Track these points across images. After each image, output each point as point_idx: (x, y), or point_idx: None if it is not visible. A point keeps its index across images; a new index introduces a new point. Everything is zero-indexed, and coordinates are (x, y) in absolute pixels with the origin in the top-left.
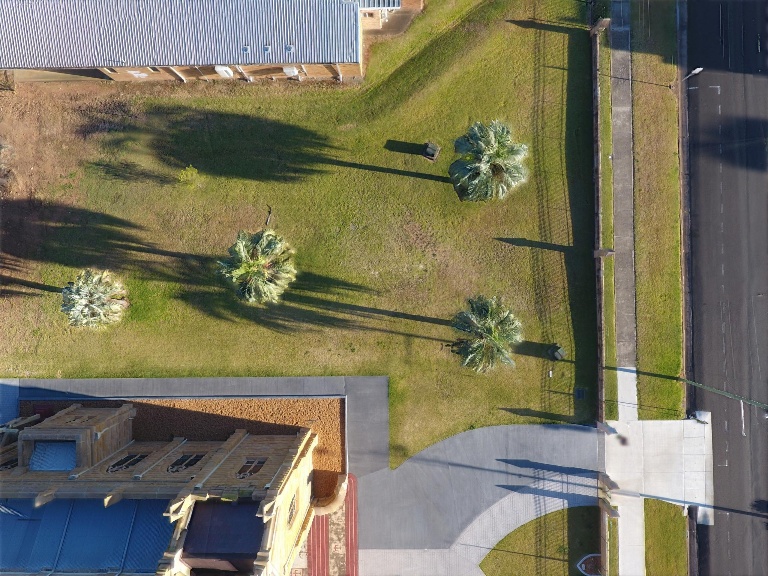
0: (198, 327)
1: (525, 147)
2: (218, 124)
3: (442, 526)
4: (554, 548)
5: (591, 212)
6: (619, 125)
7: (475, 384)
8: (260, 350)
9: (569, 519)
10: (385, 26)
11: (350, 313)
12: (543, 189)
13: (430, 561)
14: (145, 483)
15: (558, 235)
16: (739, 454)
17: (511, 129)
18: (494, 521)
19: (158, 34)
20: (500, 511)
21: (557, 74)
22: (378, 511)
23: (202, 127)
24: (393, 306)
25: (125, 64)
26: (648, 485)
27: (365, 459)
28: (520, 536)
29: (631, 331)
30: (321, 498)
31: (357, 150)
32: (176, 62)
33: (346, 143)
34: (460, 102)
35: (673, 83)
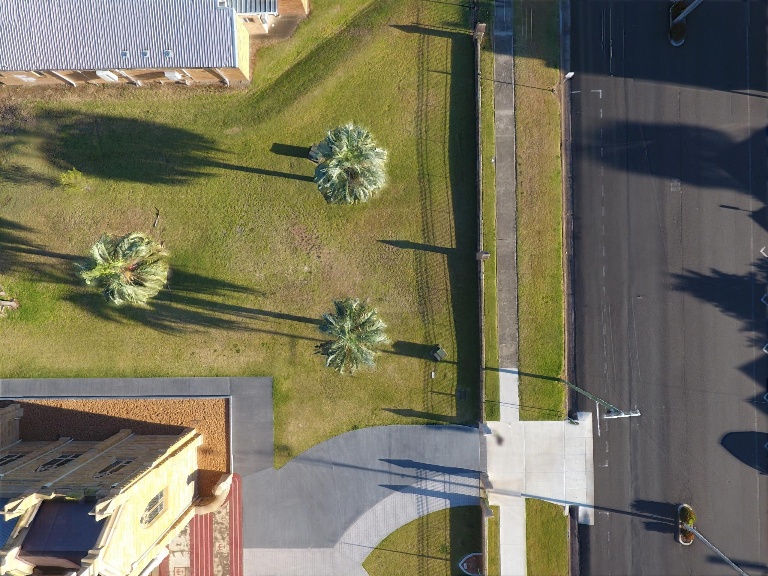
0: (86, 328)
1: (380, 151)
2: (107, 127)
3: (326, 525)
4: (436, 547)
5: (474, 215)
6: (502, 129)
7: (358, 385)
8: (147, 351)
9: (451, 519)
10: (271, 31)
11: (235, 314)
12: (426, 192)
13: (314, 560)
14: (3, 482)
15: (441, 237)
16: (619, 454)
17: (395, 132)
18: (377, 520)
19: (38, 39)
20: (383, 511)
21: (440, 78)
22: (262, 510)
23: (91, 130)
24: (278, 307)
25: (7, 68)
26: (529, 485)
27: (250, 459)
28: (403, 535)
29: (513, 332)
30: (205, 497)
31: (244, 153)
32: (57, 66)
33: (233, 146)
34: (345, 106)
35: (556, 87)
